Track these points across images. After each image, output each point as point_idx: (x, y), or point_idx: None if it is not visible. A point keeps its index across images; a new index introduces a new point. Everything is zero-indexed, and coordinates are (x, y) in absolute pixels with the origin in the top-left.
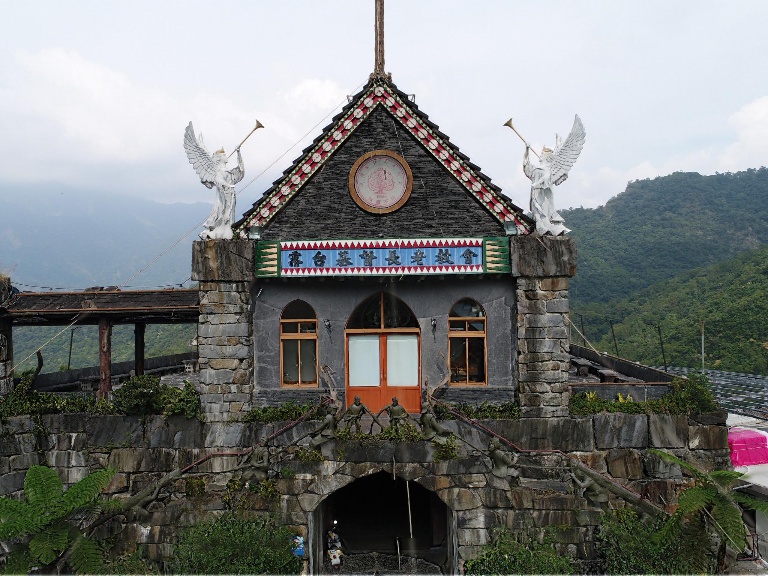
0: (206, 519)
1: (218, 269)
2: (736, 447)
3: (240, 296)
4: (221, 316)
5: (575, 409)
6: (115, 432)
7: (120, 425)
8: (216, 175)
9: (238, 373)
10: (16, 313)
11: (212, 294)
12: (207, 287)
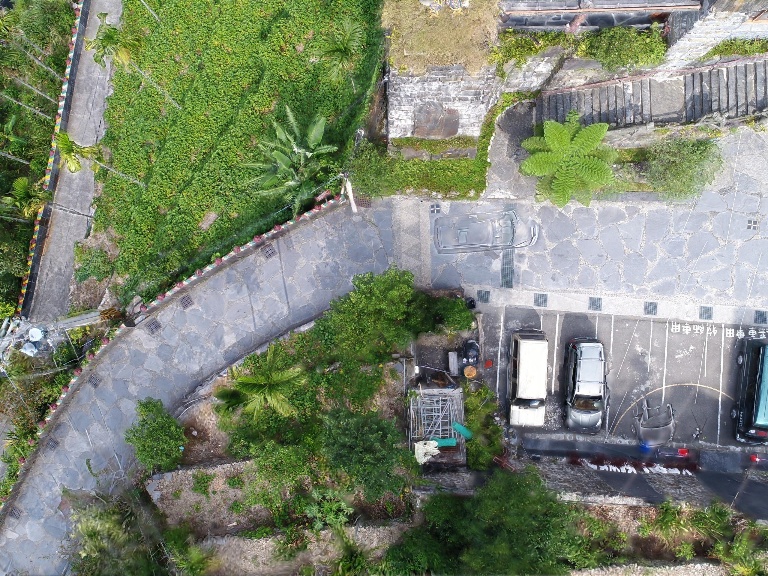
0: (662, 136)
1: (740, 7)
2: None
3: (747, 13)
4: (720, 22)
5: None
6: (587, 65)
7: (593, 63)
8: None
9: (711, 43)
10: (515, 14)
11: (721, 14)
12: (719, 11)
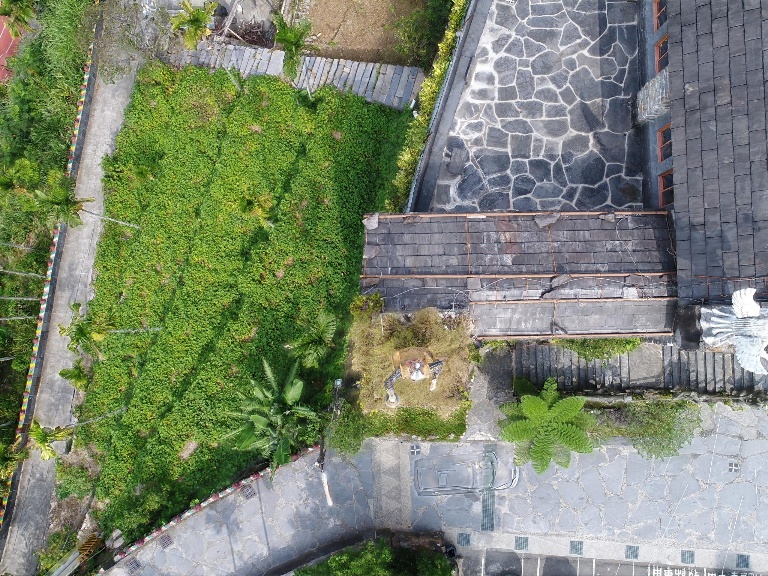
0: None
1: None
2: None
3: None
4: None
5: None
6: None
7: None
8: None
9: None
10: (487, 338)
11: None
12: None
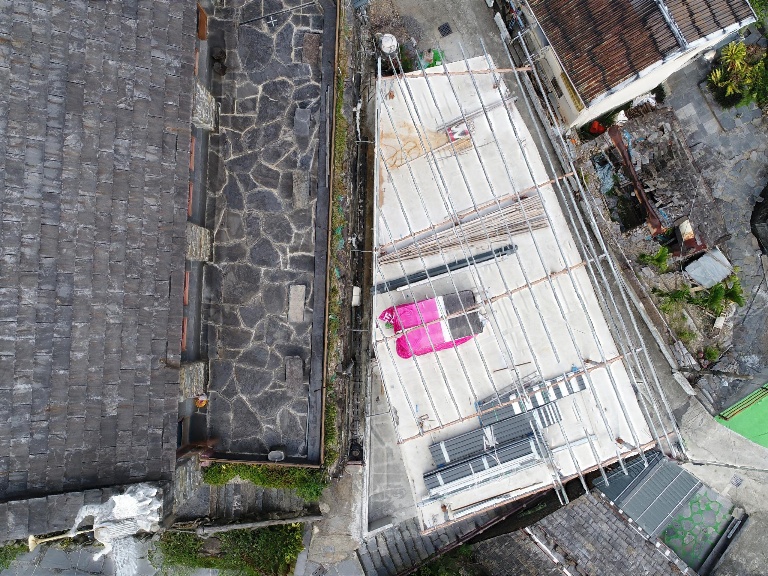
0: None
1: None
2: (410, 351)
3: None
4: None
5: (210, 483)
6: None
7: None
8: None
9: None
10: None
11: None
12: None
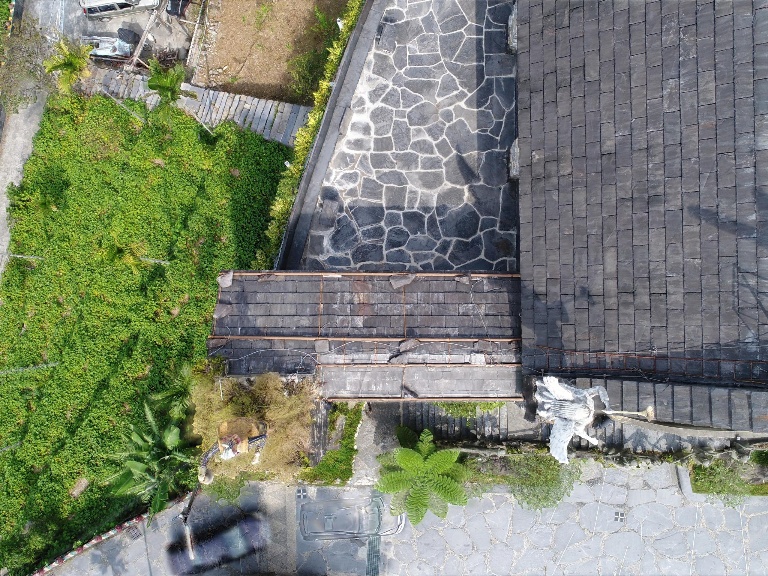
0: None
1: None
2: None
3: None
4: None
5: None
6: None
7: None
8: (576, 428)
9: None
10: (338, 400)
11: None
12: None
